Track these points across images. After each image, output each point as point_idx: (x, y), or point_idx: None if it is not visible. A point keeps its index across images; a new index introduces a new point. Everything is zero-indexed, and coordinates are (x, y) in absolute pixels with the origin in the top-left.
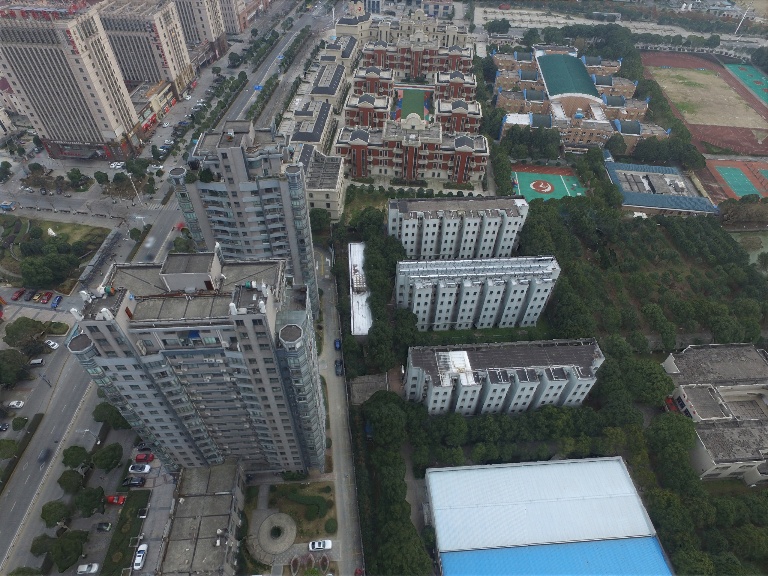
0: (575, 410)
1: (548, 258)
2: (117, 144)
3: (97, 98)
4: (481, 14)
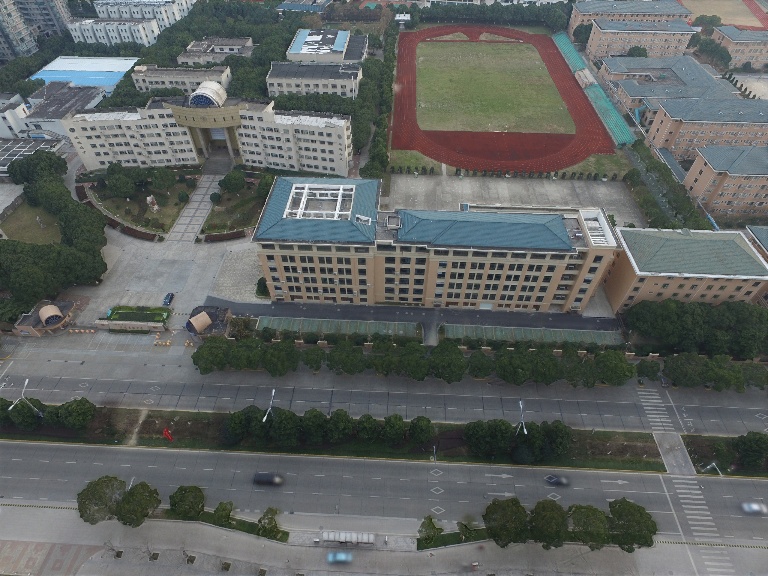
0: (131, 41)
1: (169, 1)
2: None
3: None
4: None
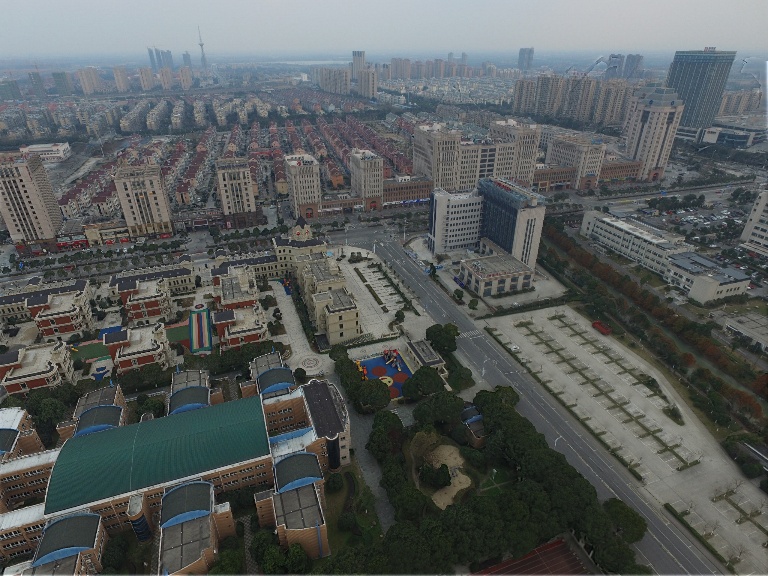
0: None
1: None
2: None
3: None
4: (540, 316)
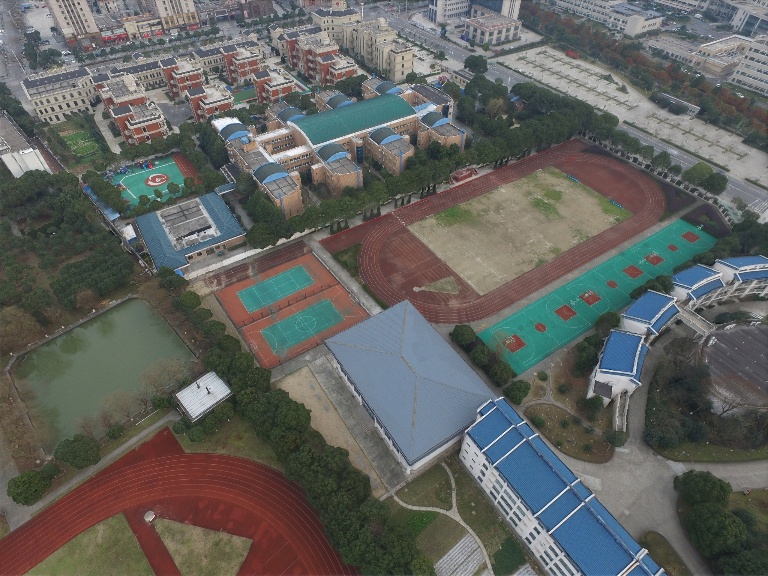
0: None
1: None
2: (65, 39)
3: (50, 4)
4: (530, 53)
